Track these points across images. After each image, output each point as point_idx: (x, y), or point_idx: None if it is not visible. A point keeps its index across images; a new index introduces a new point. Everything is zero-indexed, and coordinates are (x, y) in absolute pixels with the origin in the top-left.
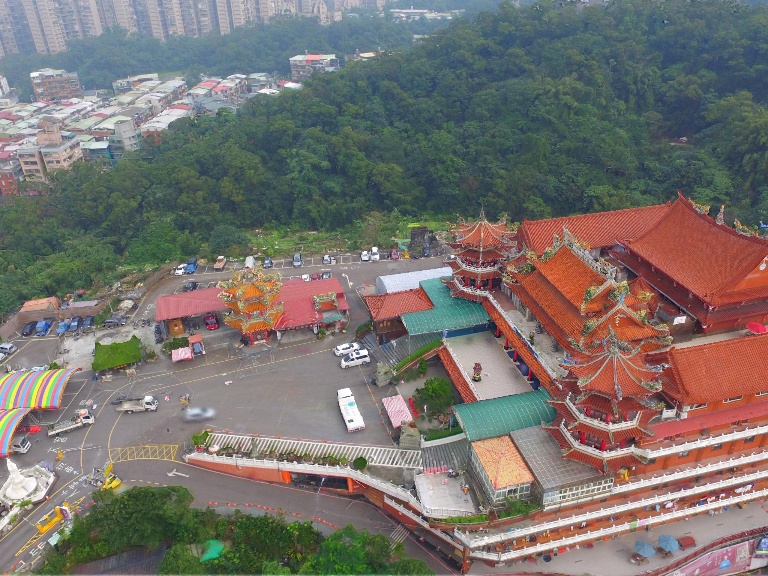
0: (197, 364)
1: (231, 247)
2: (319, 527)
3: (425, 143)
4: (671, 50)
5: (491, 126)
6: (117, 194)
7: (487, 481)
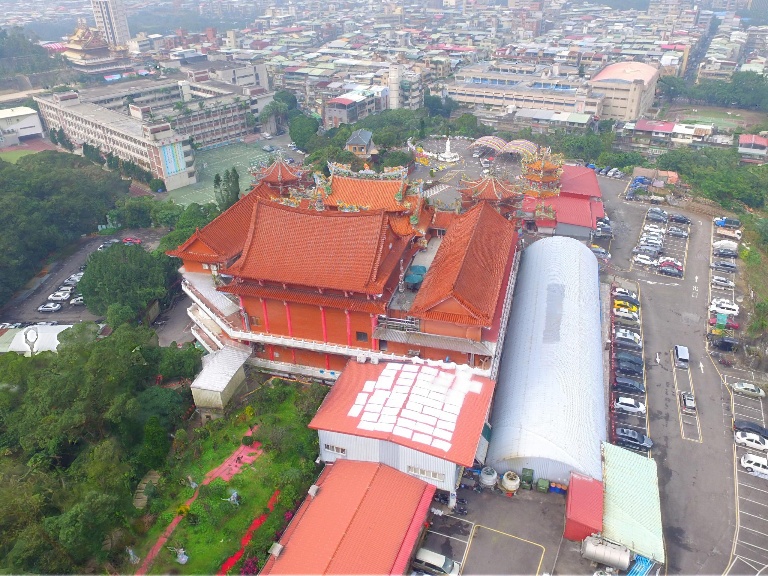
0: None
1: None
2: None
3: None
4: None
5: None
6: None
7: None
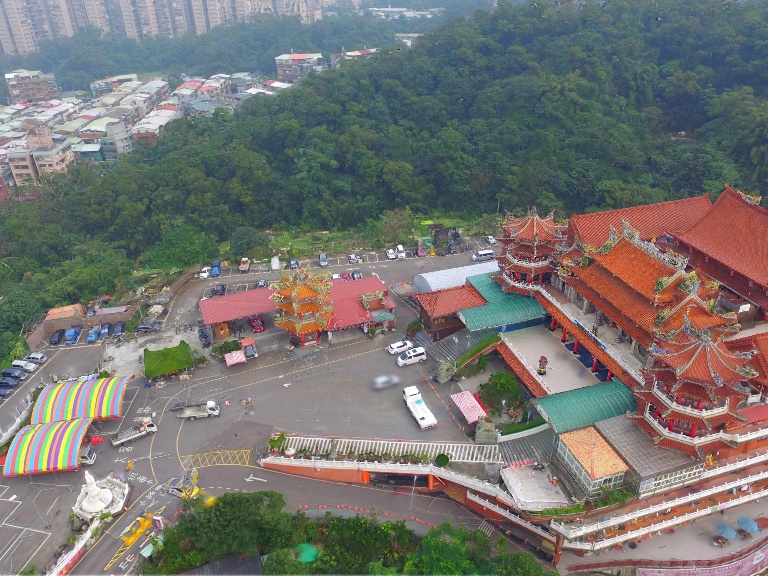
0: (250, 367)
1: (255, 248)
2: (411, 525)
3: (434, 141)
4: (667, 47)
5: (498, 123)
6: (124, 197)
7: (580, 472)
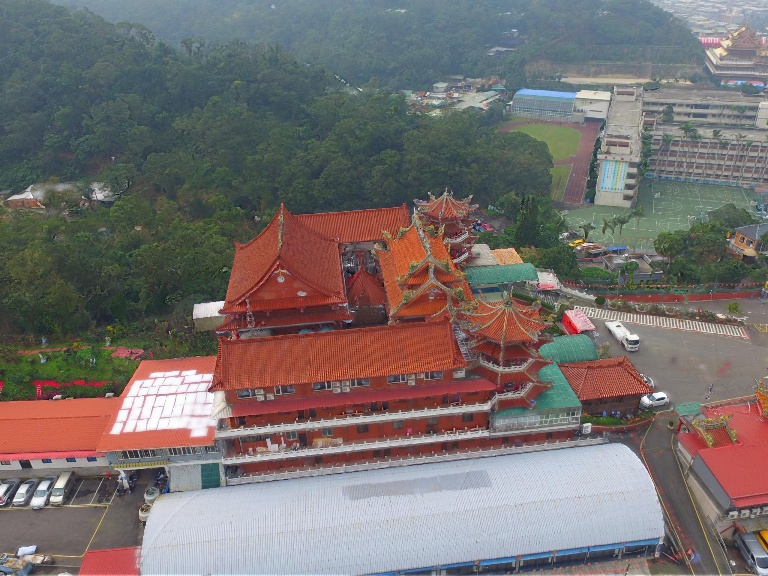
0: None
1: None
2: None
3: None
4: None
5: None
6: None
7: None
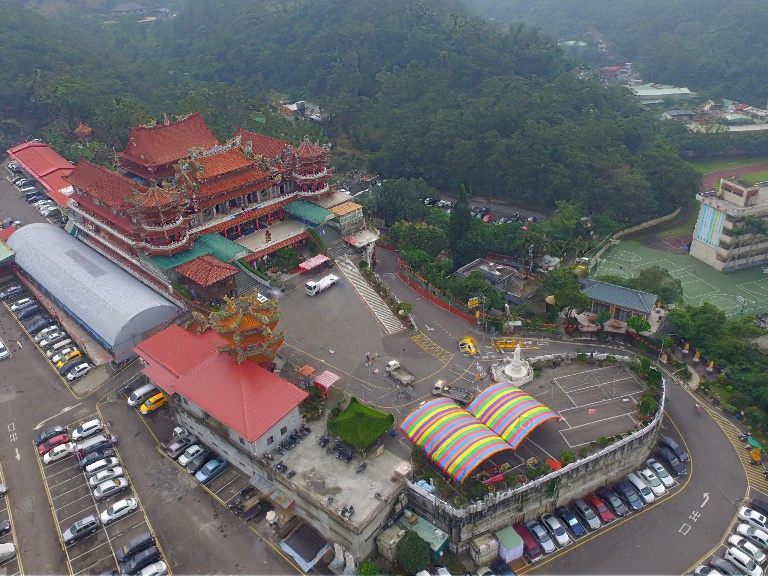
0: None
1: None
2: None
3: None
4: None
5: None
6: None
7: None
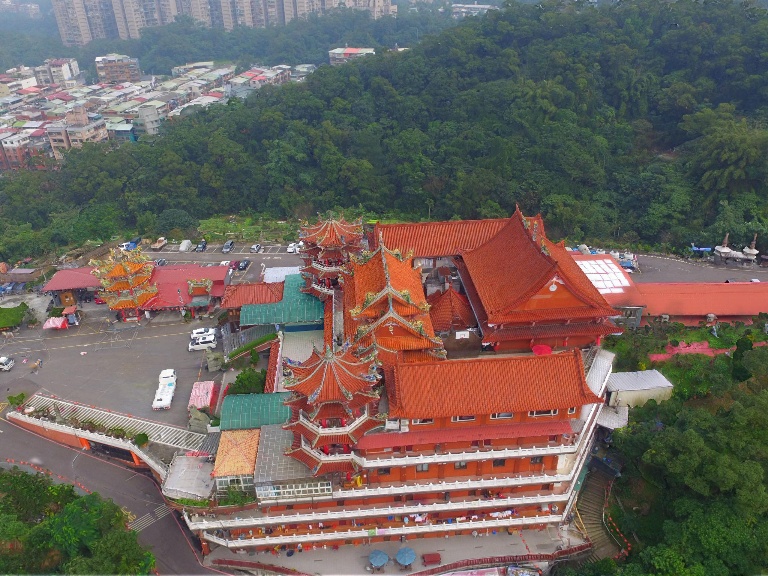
0: (69, 334)
1: (172, 230)
2: (80, 492)
3: (396, 141)
4: (675, 55)
5: (467, 127)
6: (104, 173)
7: None
